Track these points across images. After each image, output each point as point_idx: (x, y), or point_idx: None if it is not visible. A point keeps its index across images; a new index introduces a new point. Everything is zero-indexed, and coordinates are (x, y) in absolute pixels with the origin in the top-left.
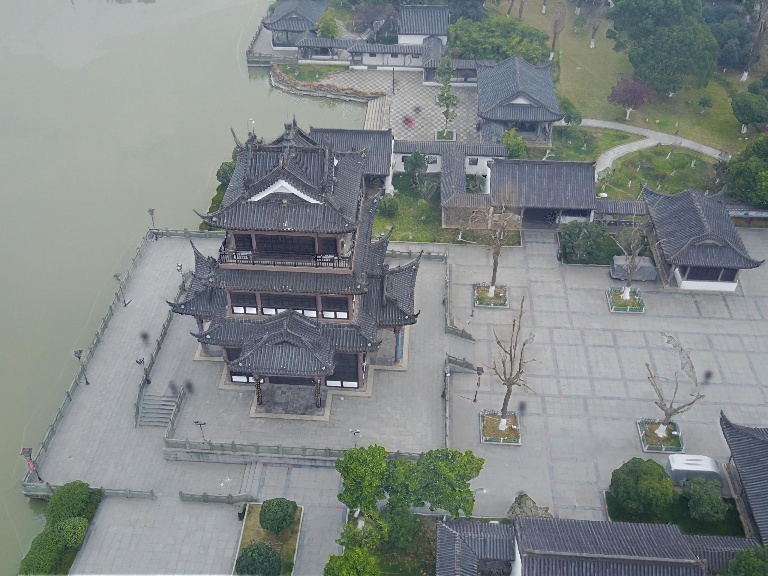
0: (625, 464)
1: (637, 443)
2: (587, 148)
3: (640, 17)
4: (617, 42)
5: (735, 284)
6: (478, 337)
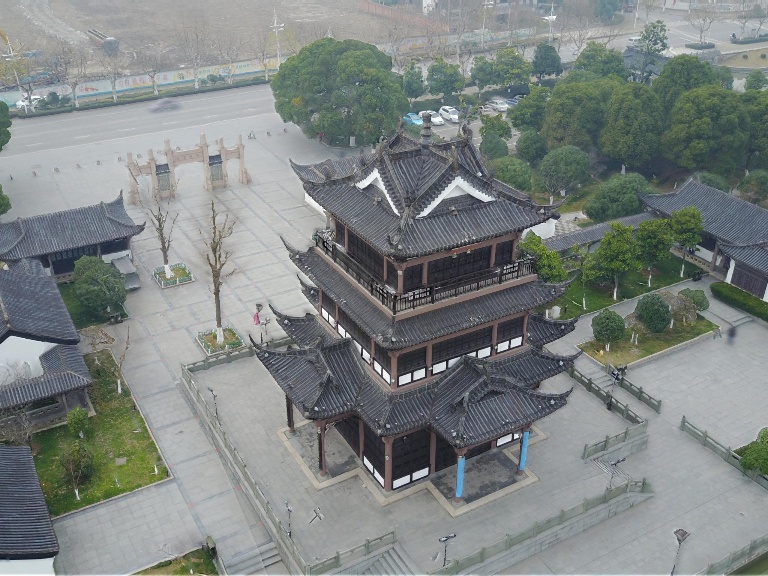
0: None
1: None
2: None
3: None
4: None
5: None
6: None
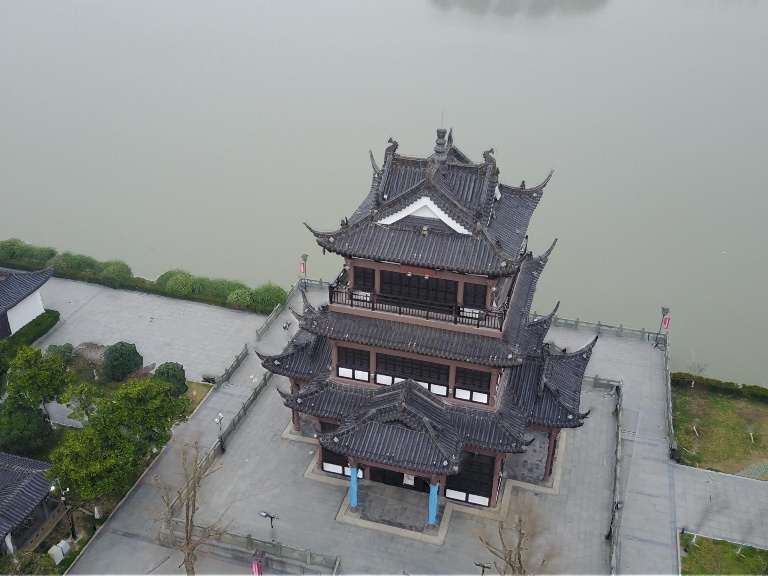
0: None
1: None
2: None
3: None
4: None
5: None
6: None
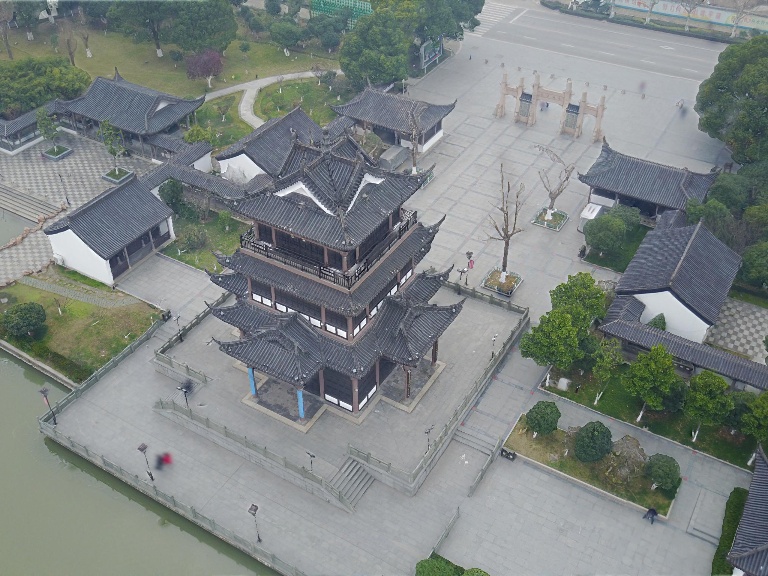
0: (589, 231)
1: (550, 231)
2: (226, 119)
3: (156, 2)
4: (141, 34)
5: (442, 130)
6: None
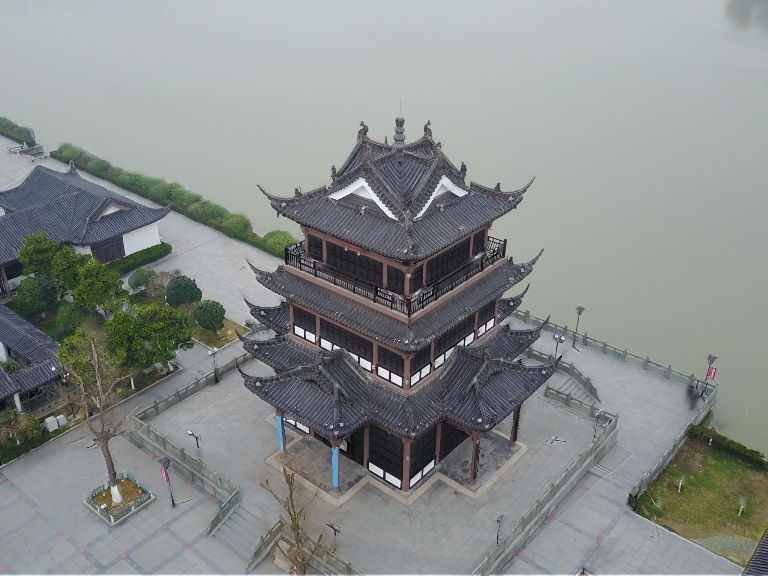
0: None
1: None
2: None
3: None
4: None
5: None
6: (253, 575)
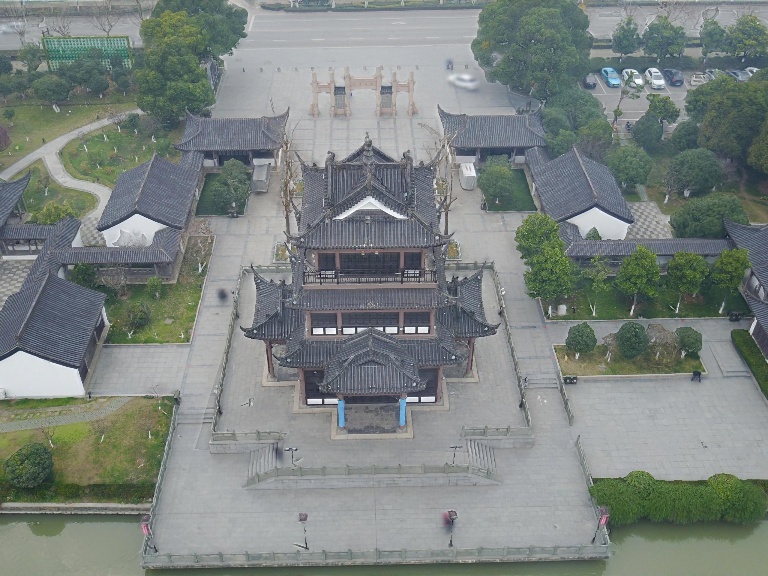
0: (488, 184)
1: None
2: (48, 191)
3: None
4: None
5: None
6: None
